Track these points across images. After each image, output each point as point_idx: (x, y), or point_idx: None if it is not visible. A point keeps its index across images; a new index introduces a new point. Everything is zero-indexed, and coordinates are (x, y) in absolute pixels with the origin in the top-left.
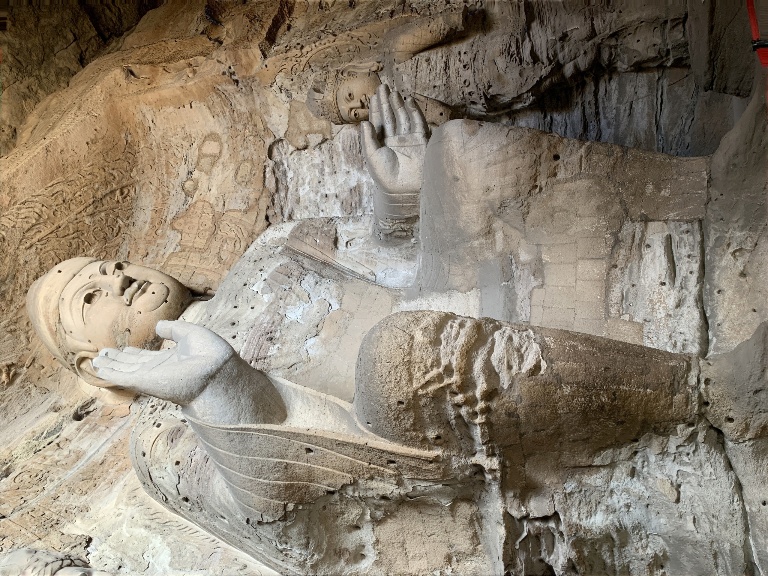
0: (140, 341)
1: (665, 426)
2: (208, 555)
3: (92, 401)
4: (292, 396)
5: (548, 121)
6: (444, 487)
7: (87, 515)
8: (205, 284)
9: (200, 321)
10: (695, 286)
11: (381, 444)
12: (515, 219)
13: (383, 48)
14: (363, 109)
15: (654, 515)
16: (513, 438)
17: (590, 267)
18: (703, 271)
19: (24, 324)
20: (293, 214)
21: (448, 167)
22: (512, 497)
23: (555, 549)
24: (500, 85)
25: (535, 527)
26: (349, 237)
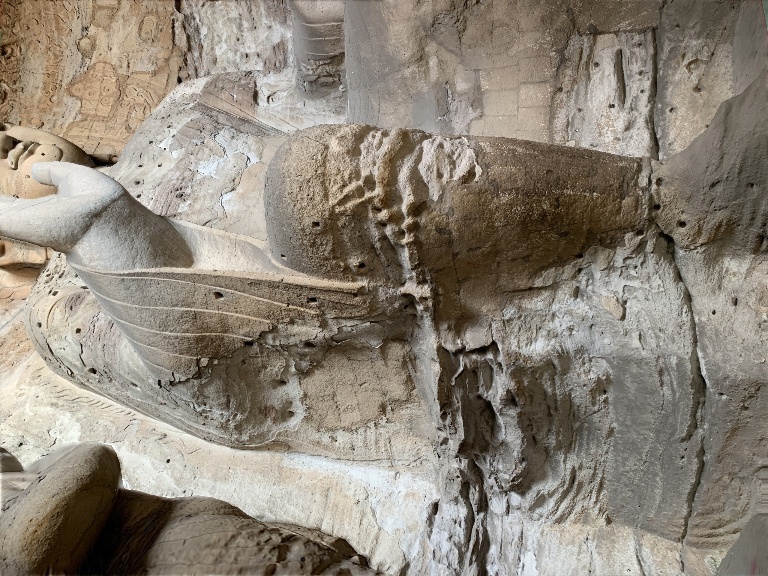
0: None
1: (612, 236)
2: (123, 427)
3: None
4: (198, 239)
5: None
6: (372, 325)
7: None
8: None
9: None
10: (646, 106)
11: (298, 279)
12: (450, 39)
13: None
14: None
15: (598, 336)
16: (445, 260)
17: (533, 92)
18: (655, 89)
19: None
20: None
21: None
22: (446, 330)
23: (493, 383)
24: None
25: (472, 361)
26: (270, 91)
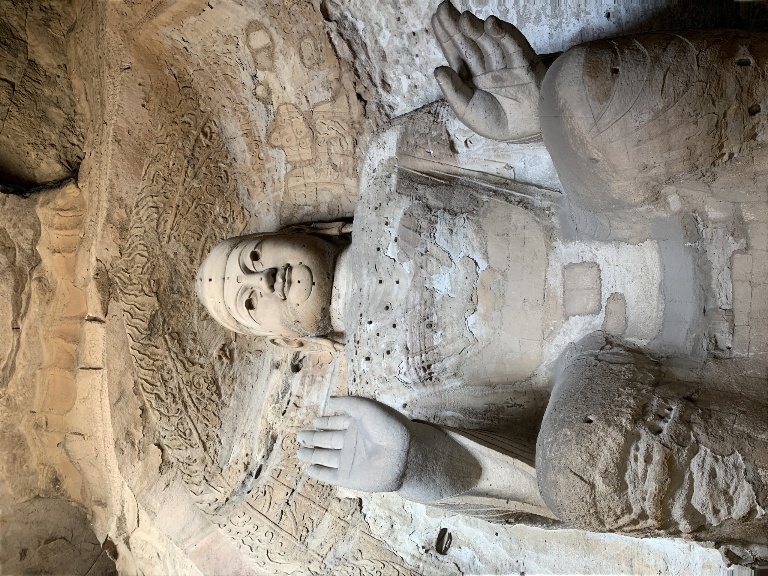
0: (311, 324)
1: None
2: None
3: None
4: (480, 455)
5: None
6: None
7: None
8: (333, 201)
9: (353, 292)
10: None
11: None
12: (694, 186)
13: None
14: None
15: None
16: None
17: None
18: None
19: None
20: (385, 77)
21: (578, 149)
22: None
23: None
24: None
25: (763, 559)
26: (466, 136)
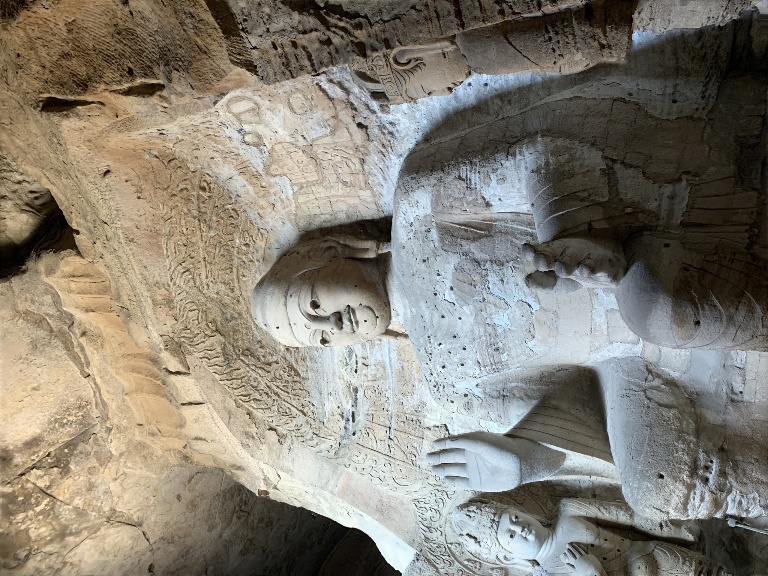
0: None
1: None
2: None
3: None
4: None
5: None
6: None
7: (428, 409)
8: (350, 209)
9: (413, 314)
10: None
11: None
12: None
13: None
14: None
15: None
16: None
17: None
18: None
19: None
20: None
21: None
22: None
23: None
24: None
25: None
26: None
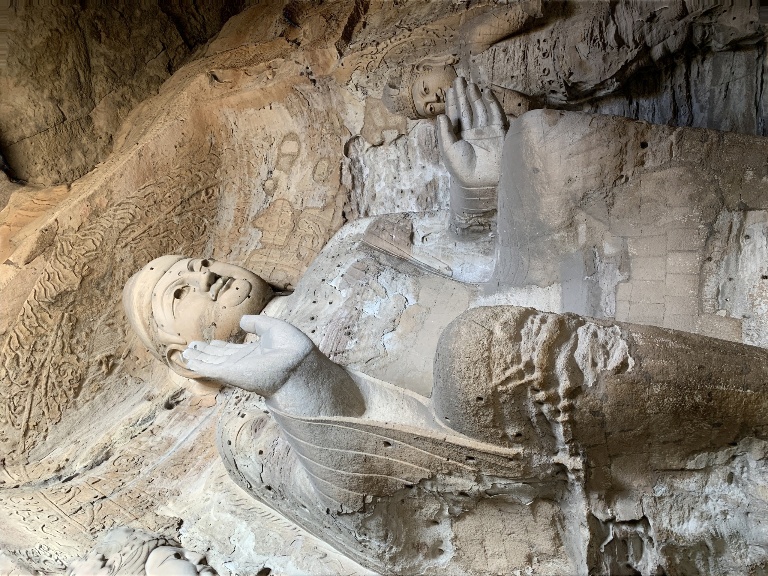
0: (225, 335)
1: (767, 430)
2: (290, 542)
3: (182, 391)
4: (370, 390)
5: (634, 107)
6: (525, 485)
7: (178, 498)
8: (285, 280)
9: (281, 316)
10: None
11: (460, 440)
12: (599, 211)
13: (459, 40)
14: (439, 103)
15: (755, 524)
16: (598, 438)
17: (681, 260)
18: None
19: (121, 318)
20: (369, 210)
21: (527, 159)
22: (597, 499)
23: (643, 555)
24: (582, 72)
25: (622, 531)
26: (425, 232)
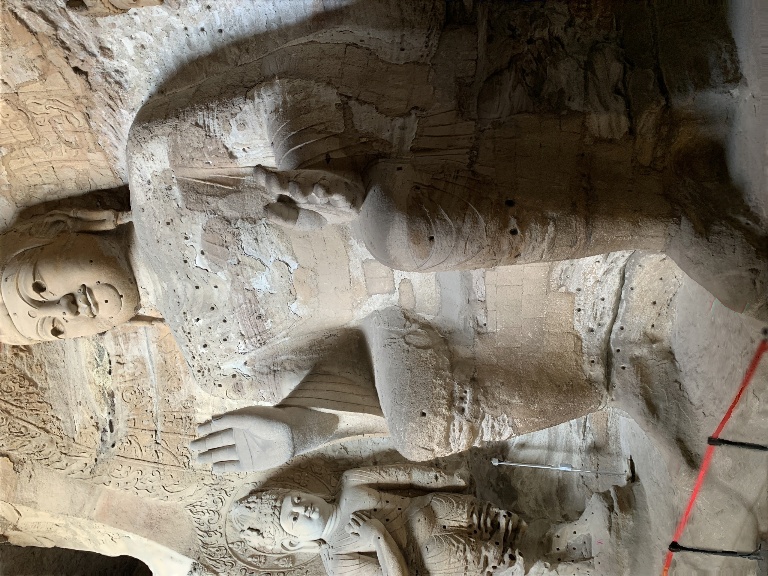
0: None
1: None
2: None
3: None
4: None
5: None
6: None
7: (198, 402)
8: (80, 177)
9: (164, 290)
10: None
11: None
12: None
13: None
14: None
15: None
16: None
17: None
18: (633, 252)
19: None
20: (102, 42)
21: None
22: None
23: None
24: None
25: None
26: None
